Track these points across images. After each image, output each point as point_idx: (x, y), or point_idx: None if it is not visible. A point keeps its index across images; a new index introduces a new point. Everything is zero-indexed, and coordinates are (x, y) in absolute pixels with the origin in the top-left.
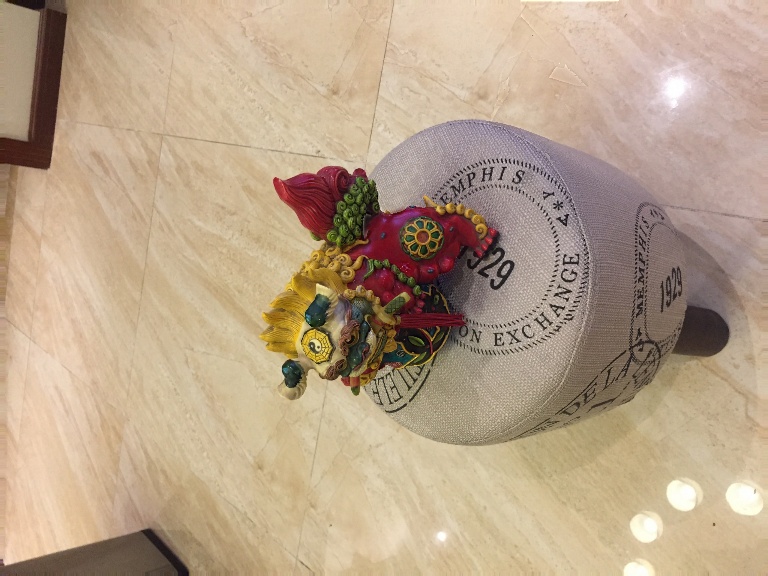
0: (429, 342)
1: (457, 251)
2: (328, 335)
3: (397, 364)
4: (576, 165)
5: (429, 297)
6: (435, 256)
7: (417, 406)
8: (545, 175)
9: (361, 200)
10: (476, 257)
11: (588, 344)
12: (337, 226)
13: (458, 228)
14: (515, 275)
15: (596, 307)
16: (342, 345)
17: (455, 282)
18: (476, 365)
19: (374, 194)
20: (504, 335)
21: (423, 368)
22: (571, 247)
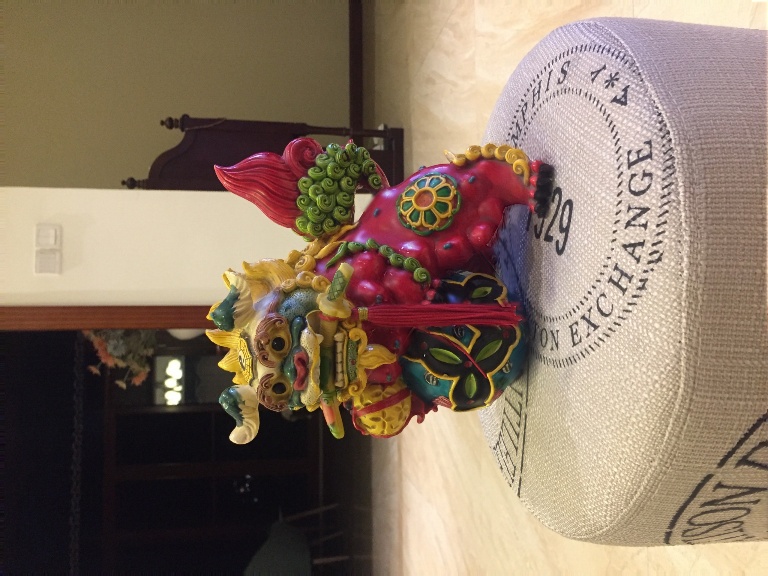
0: (466, 355)
1: (496, 212)
2: (247, 340)
3: (444, 401)
4: (678, 24)
5: (461, 288)
6: (453, 224)
7: (528, 478)
8: (594, 48)
9: (335, 171)
10: (540, 218)
11: (713, 302)
12: (304, 210)
13: (489, 177)
14: (575, 219)
15: (707, 225)
16: (258, 350)
17: (528, 267)
18: (561, 388)
19: (363, 163)
20: (579, 324)
21: (521, 414)
22: (636, 134)
